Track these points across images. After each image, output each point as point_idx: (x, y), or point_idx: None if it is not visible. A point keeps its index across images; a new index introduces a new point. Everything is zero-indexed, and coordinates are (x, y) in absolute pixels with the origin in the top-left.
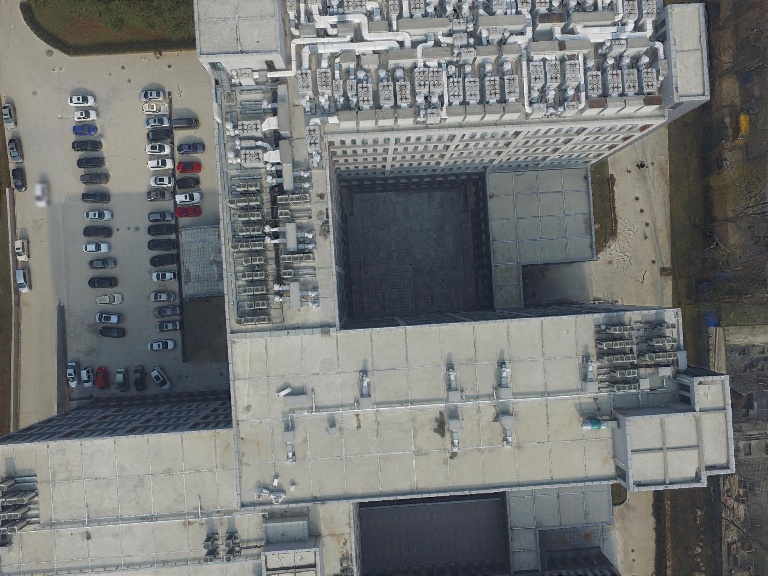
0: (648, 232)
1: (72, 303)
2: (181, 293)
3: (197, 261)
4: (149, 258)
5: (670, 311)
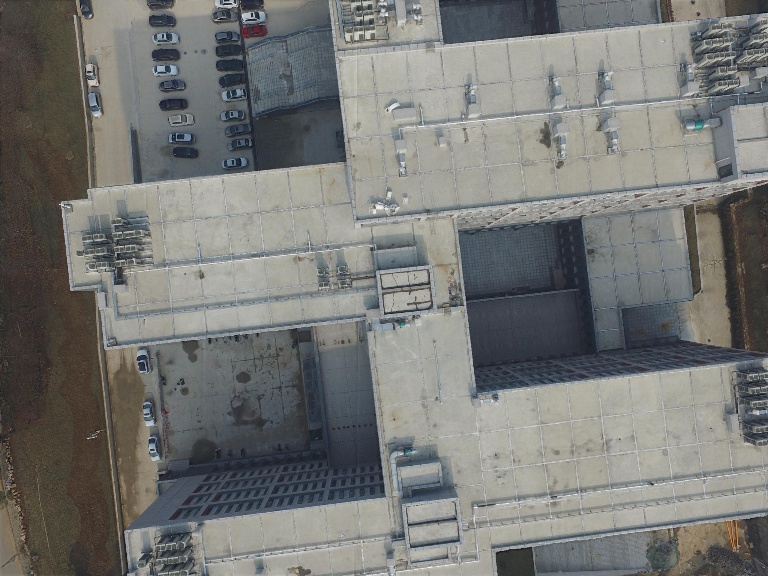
0: None
1: (144, 127)
2: (251, 113)
3: (266, 77)
4: (217, 80)
5: (763, 16)
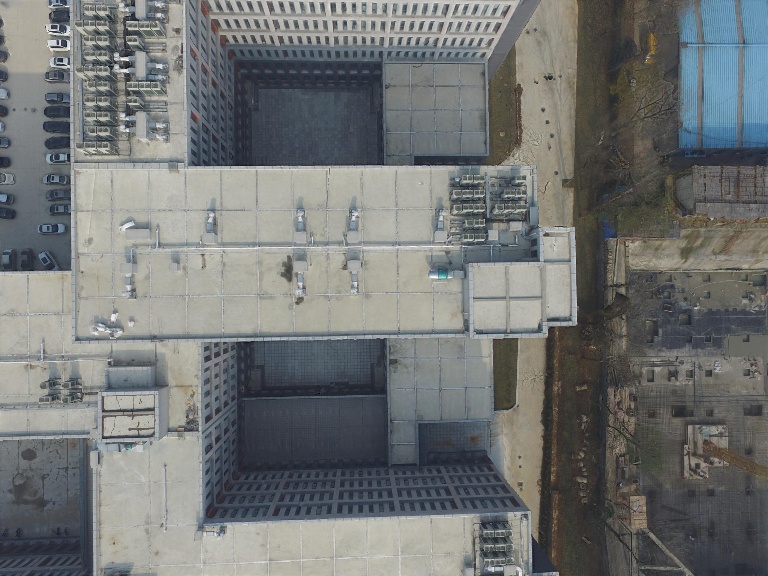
0: (552, 143)
1: None
2: None
3: None
4: (45, 140)
5: (526, 168)
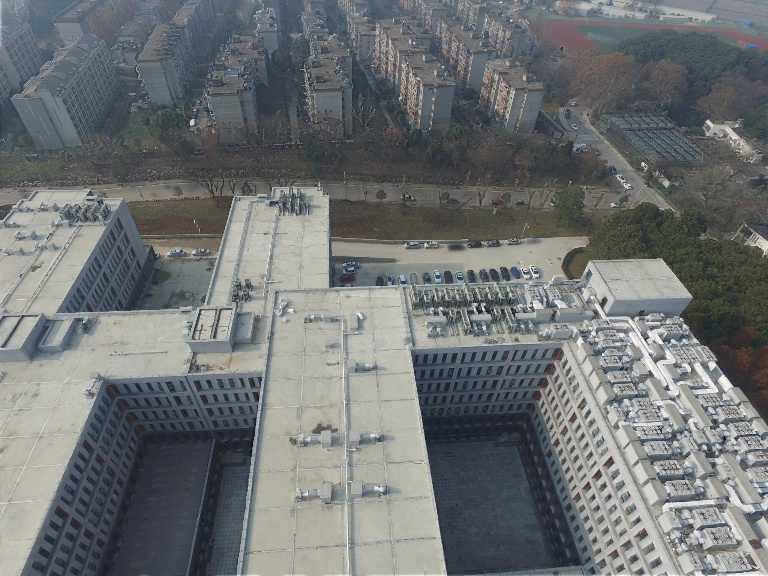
0: None
1: (399, 266)
2: None
3: None
4: None
5: None
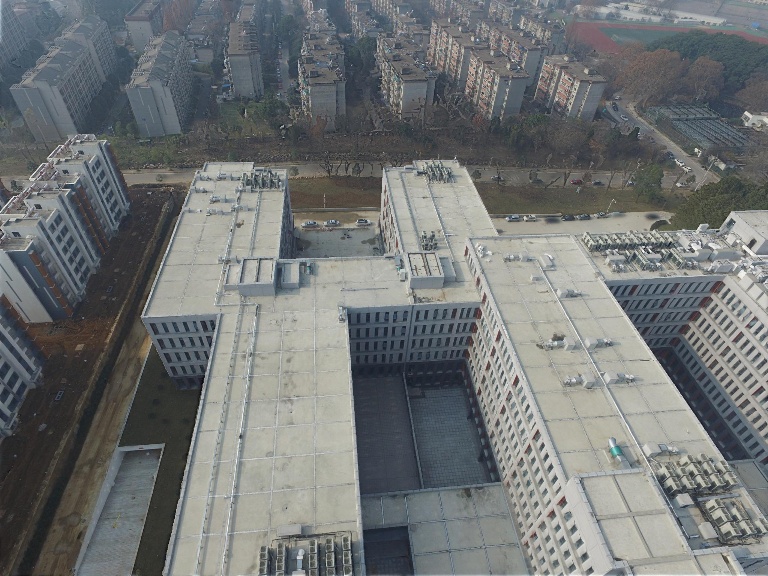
0: None
1: None
2: None
3: None
4: None
5: None
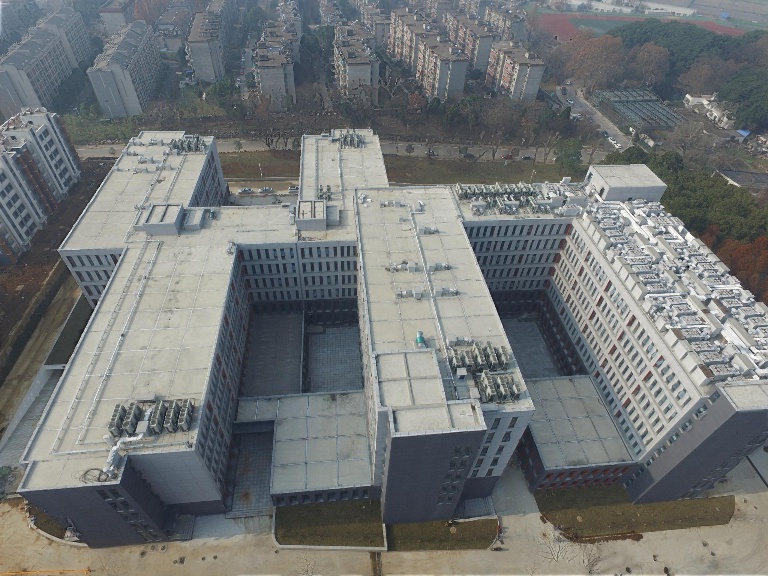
0: None
1: None
2: None
3: None
4: None
5: (530, 402)
